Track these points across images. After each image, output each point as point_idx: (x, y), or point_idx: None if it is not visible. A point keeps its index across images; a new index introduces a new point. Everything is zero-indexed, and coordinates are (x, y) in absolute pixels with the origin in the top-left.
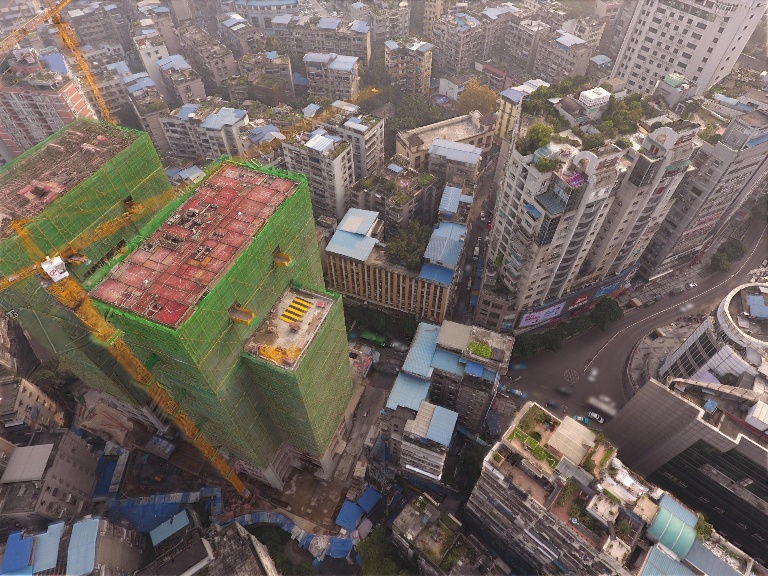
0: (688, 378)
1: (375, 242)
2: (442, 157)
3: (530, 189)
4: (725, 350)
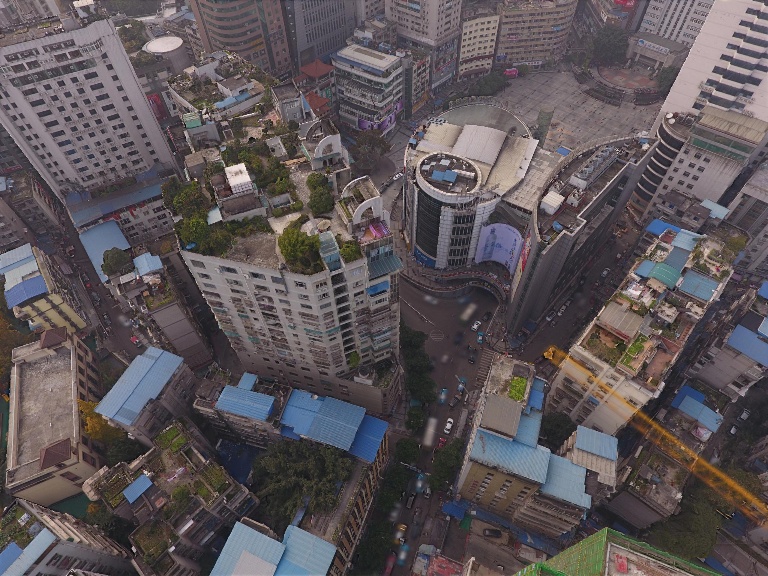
0: (468, 246)
1: (300, 530)
2: (145, 406)
3: (358, 280)
4: (480, 208)
